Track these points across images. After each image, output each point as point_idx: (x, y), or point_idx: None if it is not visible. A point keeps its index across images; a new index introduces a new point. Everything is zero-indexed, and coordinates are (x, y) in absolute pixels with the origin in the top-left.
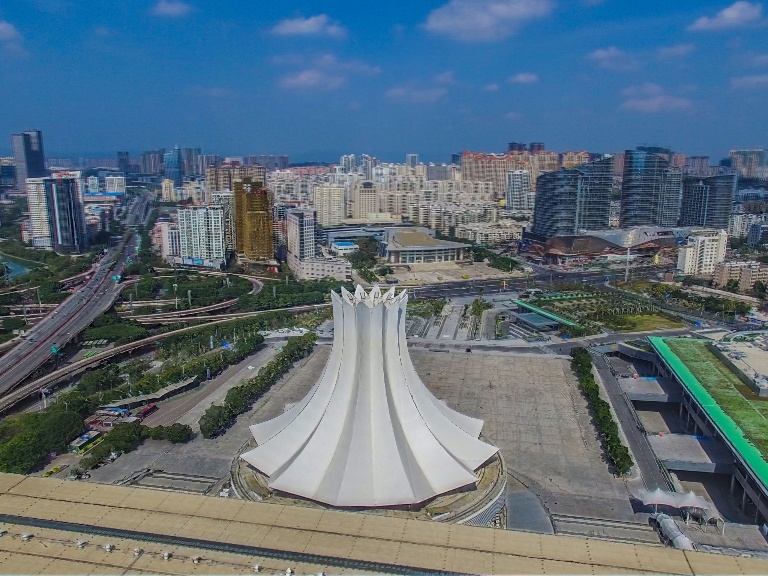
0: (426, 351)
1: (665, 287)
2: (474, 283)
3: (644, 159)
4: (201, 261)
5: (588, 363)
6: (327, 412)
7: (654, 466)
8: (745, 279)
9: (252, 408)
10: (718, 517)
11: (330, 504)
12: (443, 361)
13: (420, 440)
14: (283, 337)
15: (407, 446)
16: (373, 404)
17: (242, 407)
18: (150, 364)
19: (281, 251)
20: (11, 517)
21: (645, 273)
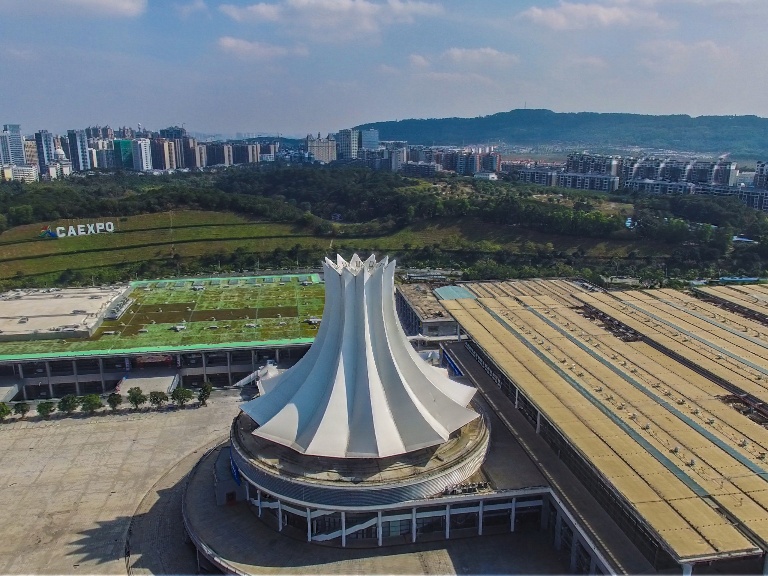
0: None
1: None
2: None
3: None
4: None
5: None
6: None
7: None
8: None
9: None
10: None
11: None
12: None
13: None
14: None
15: None
16: None
17: None
18: None
19: None
20: (676, 473)
21: None
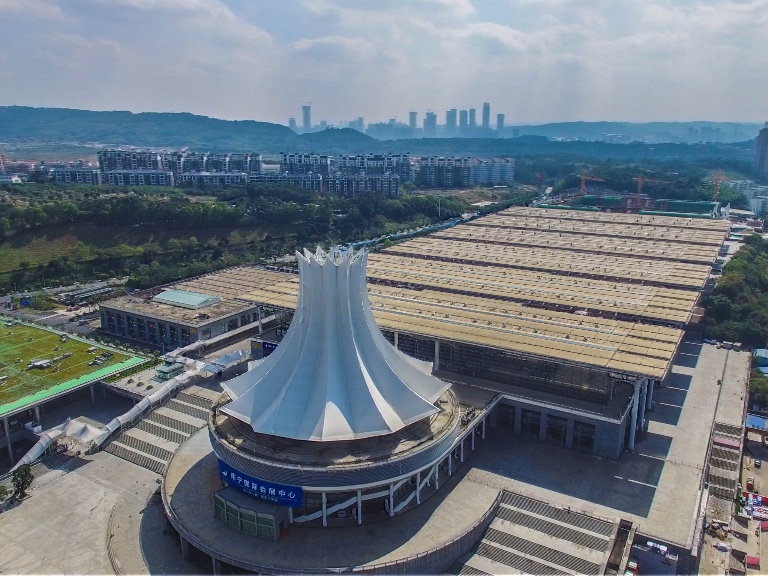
0: None
1: None
2: None
3: None
4: None
5: None
6: None
7: None
8: None
9: None
10: None
11: None
12: None
13: None
14: None
15: None
16: None
17: None
18: None
19: None
20: None
21: None
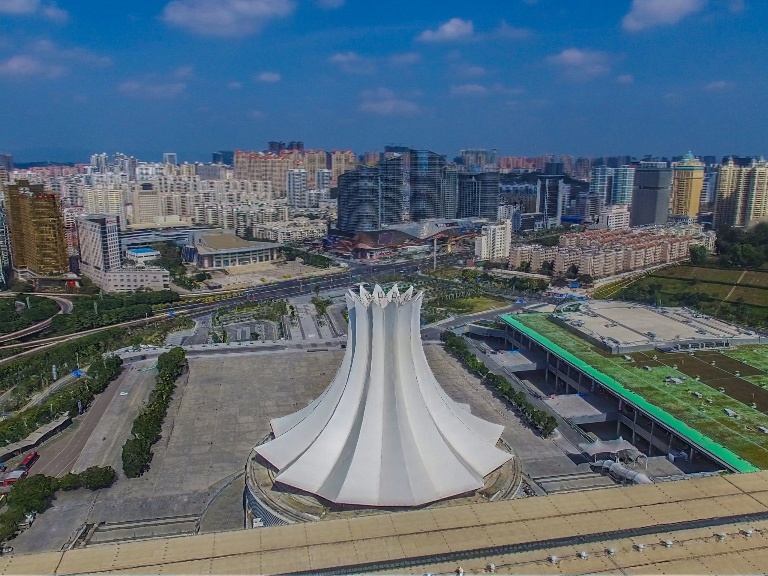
0: (305, 352)
1: (473, 272)
2: (299, 282)
3: (427, 158)
4: None
5: (465, 344)
6: (365, 417)
7: (564, 424)
8: (536, 260)
9: (161, 436)
10: (642, 454)
11: (409, 505)
12: (328, 360)
13: (452, 429)
14: (137, 356)
15: (443, 437)
16: (407, 402)
17: (154, 437)
18: None
19: (71, 263)
20: None
21: (447, 261)
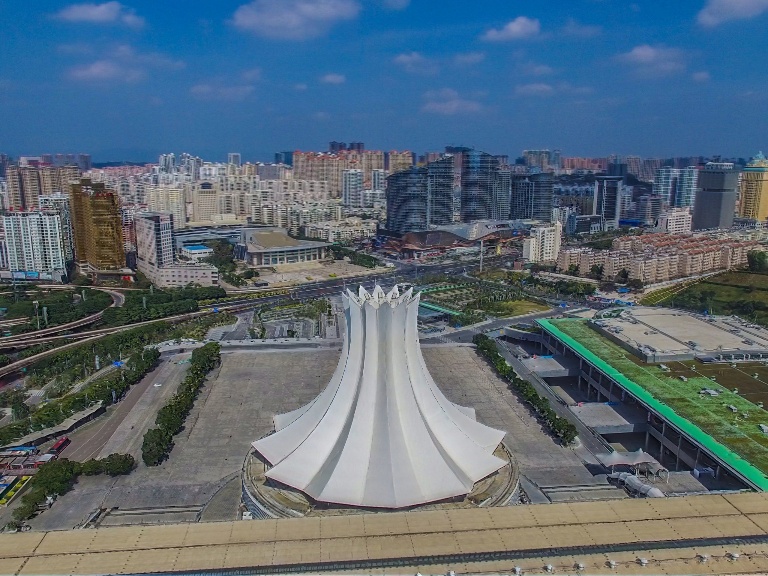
0: (336, 351)
1: (519, 274)
2: None
3: (479, 158)
4: (36, 274)
5: (496, 348)
6: (356, 417)
7: (588, 433)
8: (584, 264)
9: (184, 427)
10: (663, 468)
11: (390, 507)
12: None
13: (446, 433)
14: (176, 350)
15: (436, 440)
16: (399, 403)
17: (177, 427)
18: (25, 394)
19: (129, 258)
20: None
21: (494, 263)
